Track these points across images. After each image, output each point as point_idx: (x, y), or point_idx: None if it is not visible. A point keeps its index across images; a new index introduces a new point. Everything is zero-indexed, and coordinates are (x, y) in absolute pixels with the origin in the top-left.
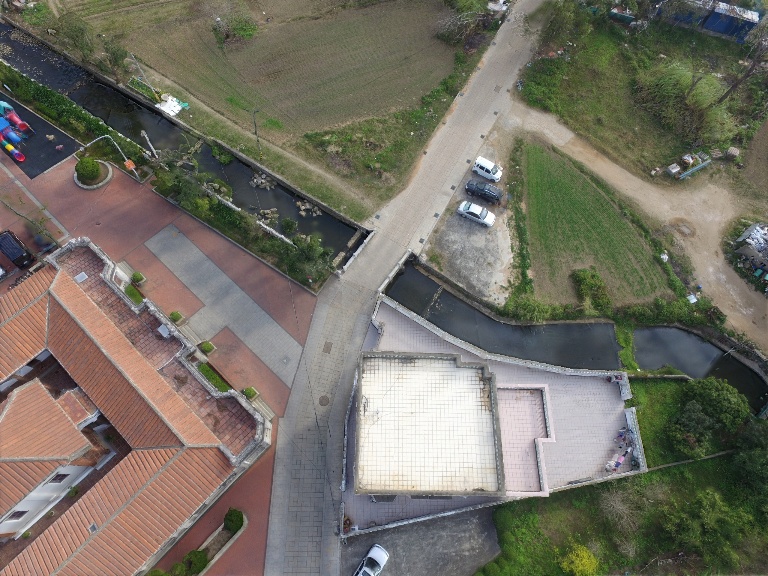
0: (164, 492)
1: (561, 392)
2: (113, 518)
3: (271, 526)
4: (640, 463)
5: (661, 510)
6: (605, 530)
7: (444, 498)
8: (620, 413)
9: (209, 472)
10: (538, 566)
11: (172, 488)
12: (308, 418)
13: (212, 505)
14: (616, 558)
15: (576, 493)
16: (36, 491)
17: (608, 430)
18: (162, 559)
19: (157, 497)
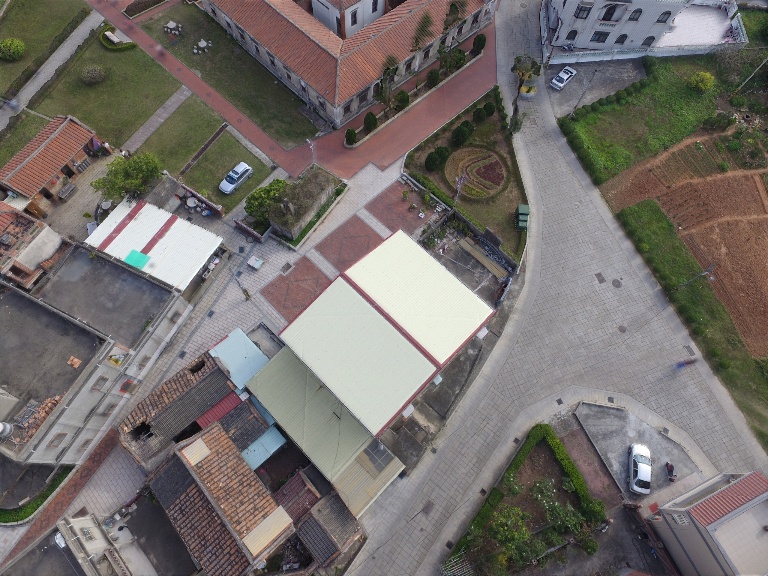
0: (448, 3)
1: (686, 12)
2: (423, 6)
3: (498, 57)
4: (743, 41)
5: (758, 56)
6: (717, 75)
7: (627, 2)
8: (727, 24)
9: (471, 1)
10: (673, 87)
11: (452, 2)
12: (514, 12)
13: (460, 44)
14: (725, 87)
15: (697, 58)
16: (368, 2)
17: (719, 31)
18: (434, 63)
19: (444, 4)
